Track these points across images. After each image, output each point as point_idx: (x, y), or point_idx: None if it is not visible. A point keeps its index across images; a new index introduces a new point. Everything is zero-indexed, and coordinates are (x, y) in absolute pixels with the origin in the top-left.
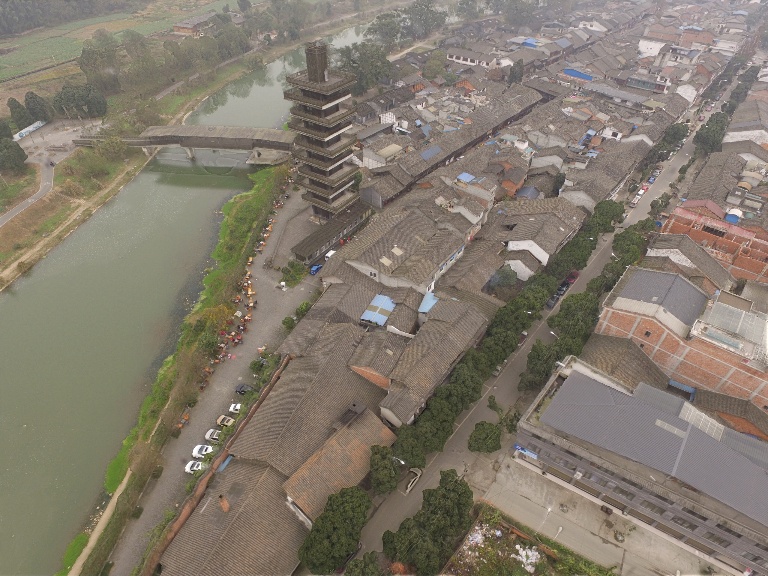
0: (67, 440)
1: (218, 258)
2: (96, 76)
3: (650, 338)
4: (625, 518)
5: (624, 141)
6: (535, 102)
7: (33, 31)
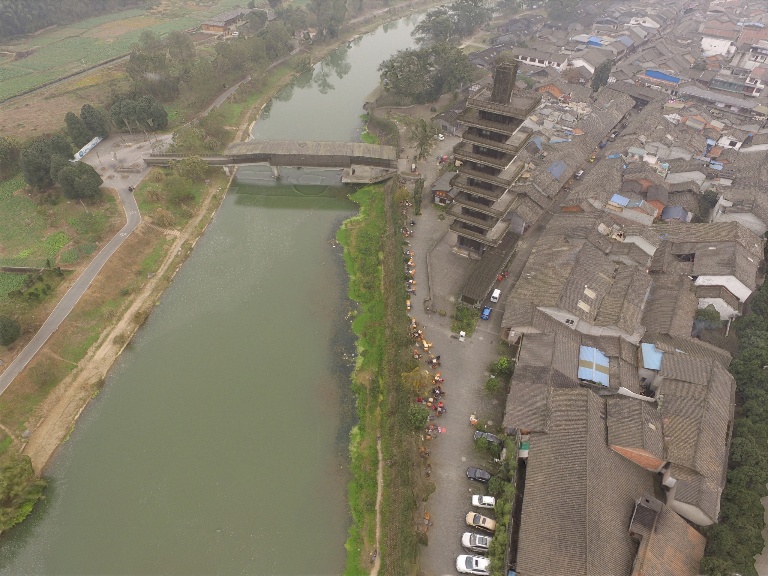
0: (277, 548)
1: (357, 299)
2: (147, 84)
3: None
4: None
5: (743, 151)
6: None
7: (46, 30)
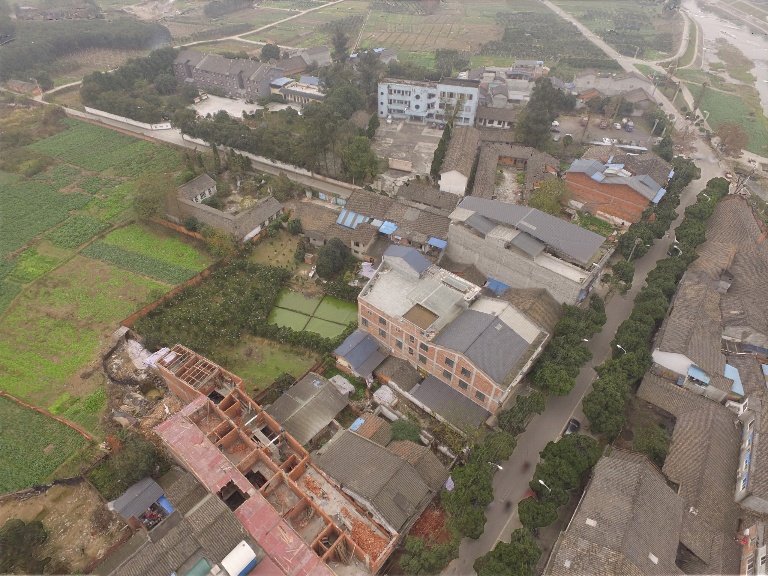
0: None
1: None
2: None
3: None
4: None
5: None
6: None
7: None
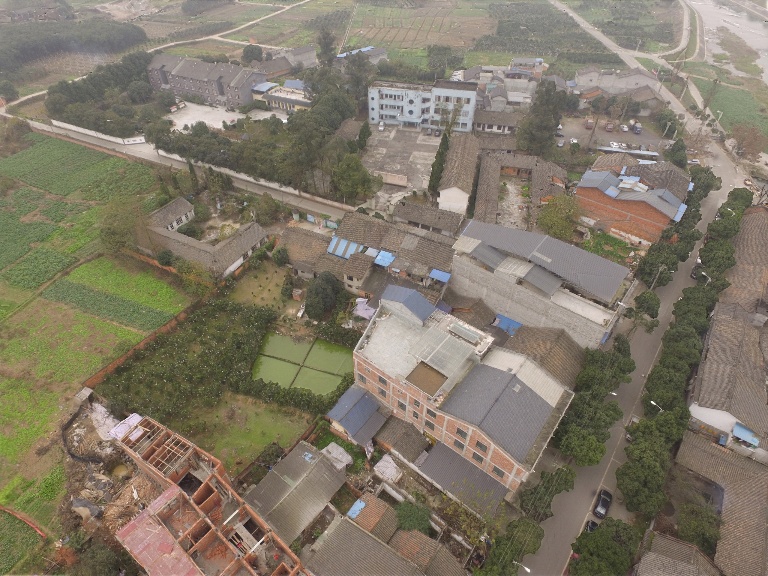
0: None
1: None
2: None
3: None
4: None
5: None
6: None
7: None
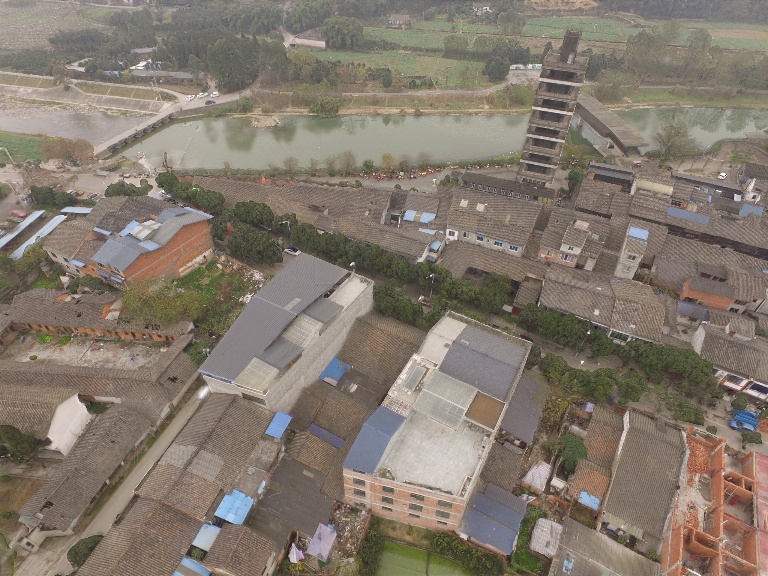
0: None
1: None
2: None
3: None
4: None
5: None
6: None
7: (690, 20)
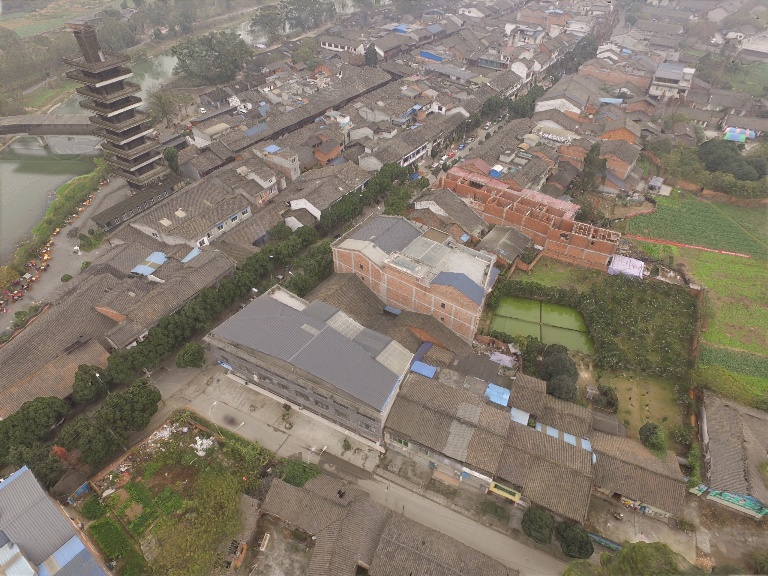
0: None
1: (37, 232)
2: None
3: (364, 270)
4: (300, 412)
5: (448, 114)
6: (382, 83)
7: None
